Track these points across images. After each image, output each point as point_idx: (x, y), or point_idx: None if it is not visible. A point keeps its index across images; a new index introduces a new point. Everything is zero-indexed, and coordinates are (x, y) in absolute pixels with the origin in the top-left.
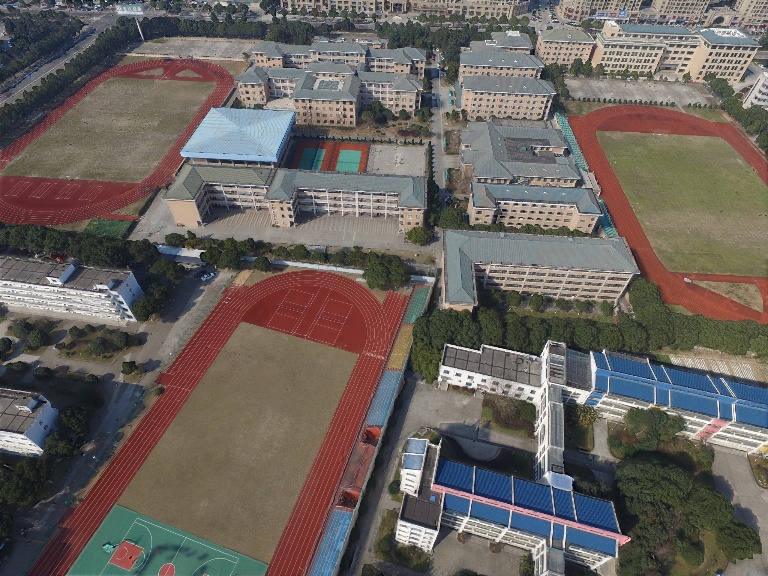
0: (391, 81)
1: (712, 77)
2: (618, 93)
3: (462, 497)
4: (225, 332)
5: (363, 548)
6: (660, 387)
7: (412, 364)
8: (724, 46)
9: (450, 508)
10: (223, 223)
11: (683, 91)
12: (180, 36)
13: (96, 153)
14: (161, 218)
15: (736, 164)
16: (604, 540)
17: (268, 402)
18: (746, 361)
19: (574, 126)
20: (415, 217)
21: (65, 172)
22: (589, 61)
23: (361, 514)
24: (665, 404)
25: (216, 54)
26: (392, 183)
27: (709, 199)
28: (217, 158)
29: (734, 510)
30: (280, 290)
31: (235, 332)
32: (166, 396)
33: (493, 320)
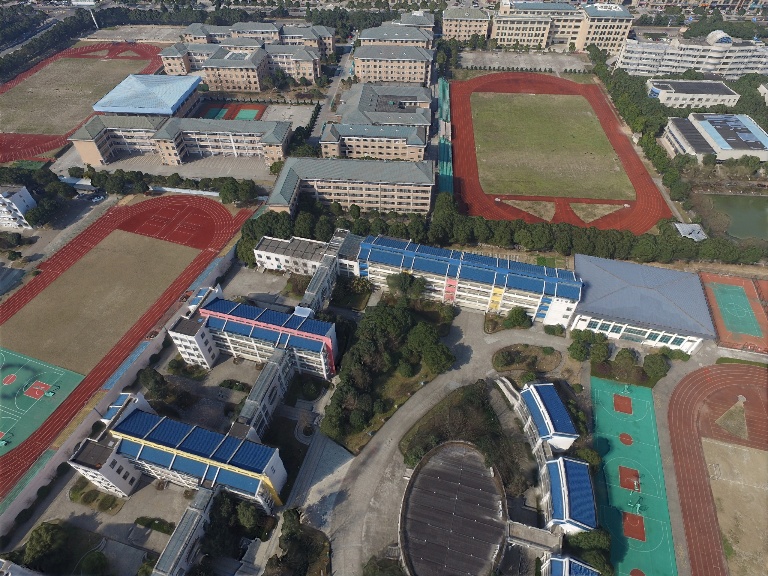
0: (293, 52)
1: (592, 47)
2: (506, 63)
3: (221, 318)
4: (100, 236)
5: (160, 367)
6: (407, 255)
7: (237, 253)
8: (602, 19)
9: (211, 326)
10: (123, 163)
11: (566, 60)
12: (131, 24)
13: (33, 114)
14: (73, 160)
15: (585, 116)
16: (315, 343)
17: (119, 280)
18: (518, 254)
19: (454, 89)
20: (276, 153)
21: (3, 128)
22: (483, 36)
23: (165, 347)
24: (409, 267)
25: (158, 38)
26: (259, 126)
27: (547, 142)
28: (124, 112)
29: (457, 347)
30: (154, 208)
31: (108, 236)
32: (41, 276)
33: (305, 219)
